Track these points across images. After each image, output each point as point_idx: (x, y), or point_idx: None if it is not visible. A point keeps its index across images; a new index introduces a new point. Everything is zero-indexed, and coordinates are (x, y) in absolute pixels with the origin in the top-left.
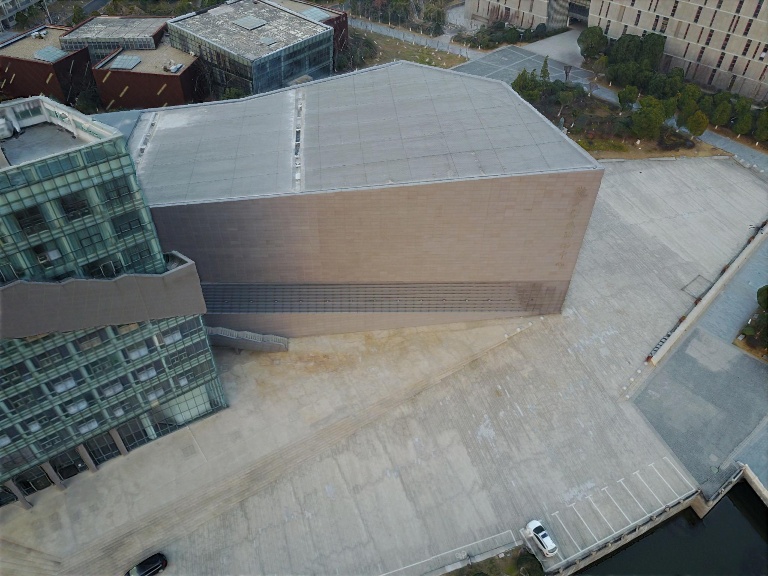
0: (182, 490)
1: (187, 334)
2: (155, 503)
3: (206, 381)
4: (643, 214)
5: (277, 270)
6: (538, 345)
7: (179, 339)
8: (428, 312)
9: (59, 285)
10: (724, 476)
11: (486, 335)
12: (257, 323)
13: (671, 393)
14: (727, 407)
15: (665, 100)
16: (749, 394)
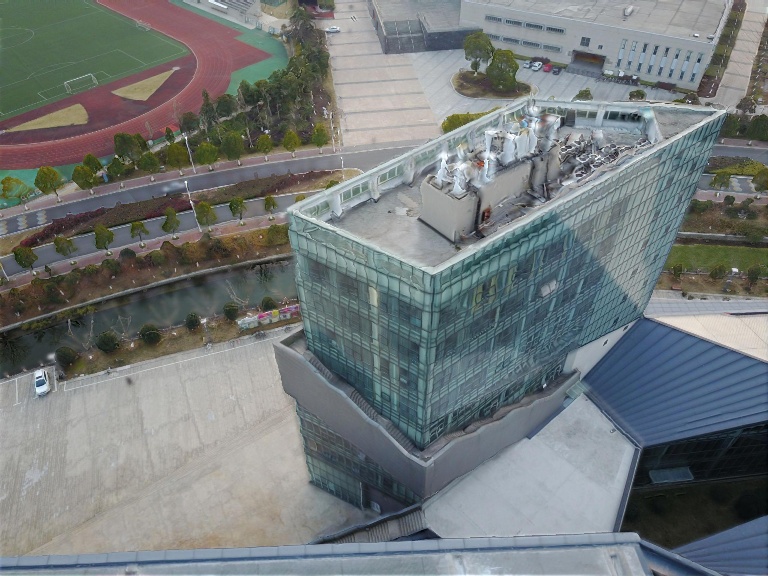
0: None
1: None
2: None
3: None
4: None
5: None
6: None
7: None
8: None
9: None
10: None
11: None
12: None
13: None
14: None
15: None
16: None
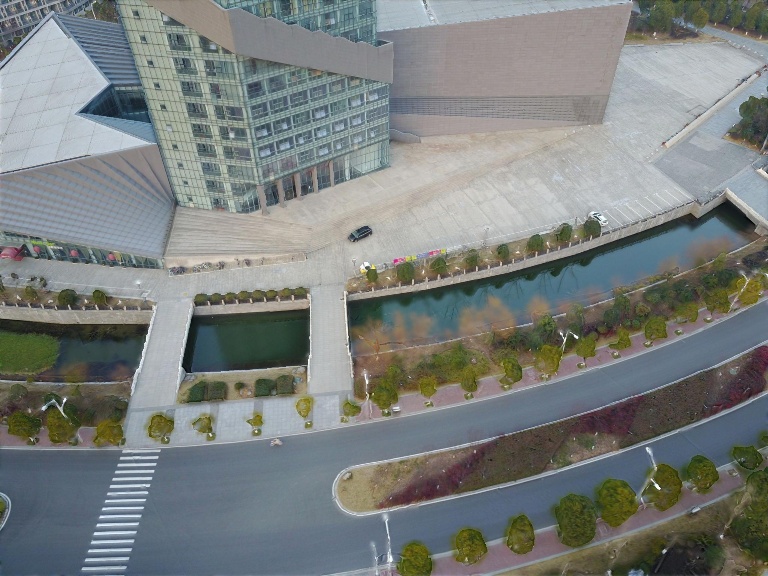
0: (373, 200)
1: (380, 98)
2: (359, 205)
3: (383, 139)
4: (659, 74)
5: (414, 87)
6: (588, 139)
7: (377, 99)
8: (513, 119)
9: (335, 38)
10: (712, 195)
11: (552, 134)
12: (401, 123)
13: (679, 160)
14: (716, 166)
15: (675, 3)
16: (731, 161)
